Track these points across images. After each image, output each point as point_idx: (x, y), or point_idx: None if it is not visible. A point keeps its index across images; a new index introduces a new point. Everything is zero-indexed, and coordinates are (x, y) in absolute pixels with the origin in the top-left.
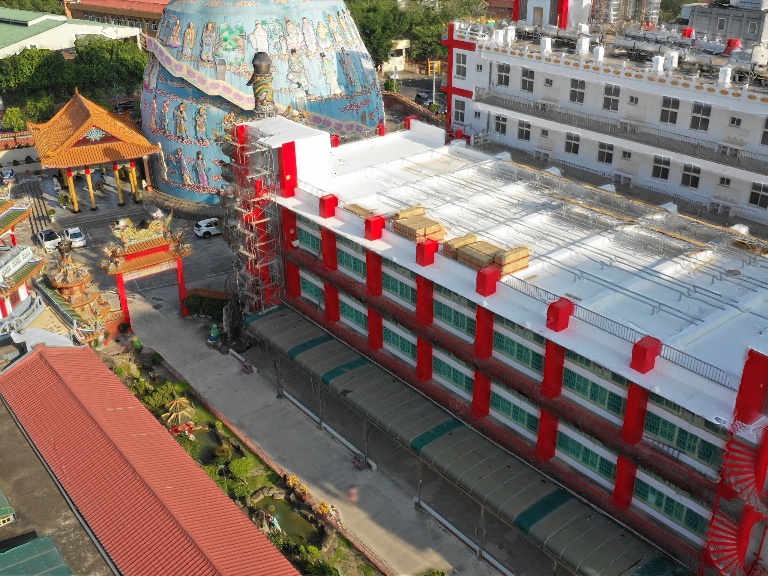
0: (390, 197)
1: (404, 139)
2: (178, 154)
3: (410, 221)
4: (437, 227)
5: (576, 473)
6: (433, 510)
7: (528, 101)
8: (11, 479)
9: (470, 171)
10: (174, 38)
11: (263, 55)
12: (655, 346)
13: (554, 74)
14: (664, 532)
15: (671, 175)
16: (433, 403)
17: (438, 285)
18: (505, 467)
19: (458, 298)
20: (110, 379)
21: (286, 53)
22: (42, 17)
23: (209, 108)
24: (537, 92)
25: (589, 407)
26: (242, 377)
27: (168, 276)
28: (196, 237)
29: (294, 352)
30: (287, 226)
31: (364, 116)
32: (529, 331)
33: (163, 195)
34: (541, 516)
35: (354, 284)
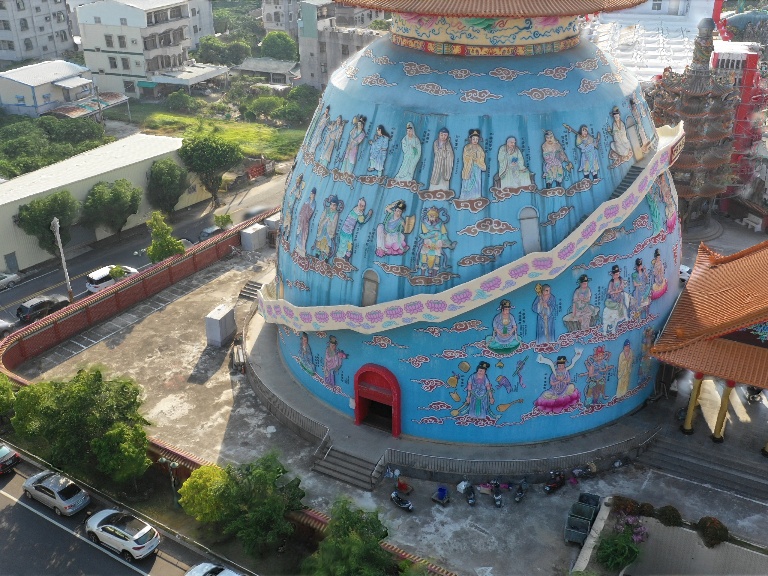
0: None
1: None
2: None
3: None
4: None
5: None
6: None
7: None
8: None
9: None
10: None
11: None
12: None
13: None
14: None
15: None
16: None
17: None
18: None
19: None
20: None
21: None
22: None
23: None
24: None
25: None
26: None
27: None
28: None
29: None
30: None
31: None
32: None
33: None
34: None
35: None
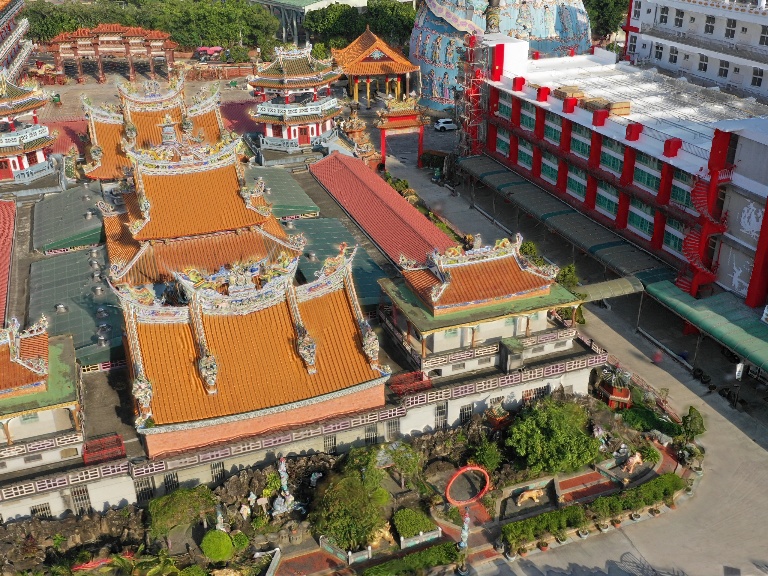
0: (561, 83)
1: (588, 60)
2: (431, 74)
3: (565, 90)
4: (581, 94)
5: None
6: (549, 260)
7: (674, 31)
8: (317, 203)
9: (624, 77)
10: None
11: None
12: (677, 142)
13: (695, 13)
14: None
15: (763, 83)
16: (562, 202)
17: (575, 127)
18: (594, 229)
19: (585, 134)
20: (373, 173)
21: (519, 3)
22: None
23: (458, 41)
24: (684, 27)
25: None
26: (450, 197)
27: (412, 148)
28: (435, 130)
29: (484, 175)
30: (493, 101)
31: None
32: (619, 147)
33: None
34: (605, 247)
35: (526, 131)
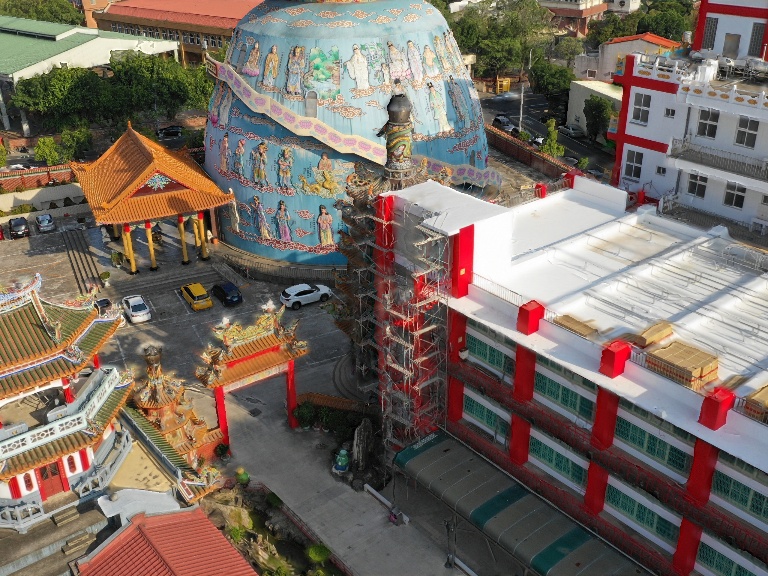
0: (606, 301)
1: (568, 201)
2: (255, 203)
3: (673, 353)
4: (714, 364)
5: None
6: None
7: (758, 162)
8: None
9: (685, 254)
10: (252, 65)
11: (403, 99)
12: None
13: None
14: None
15: None
16: None
17: None
18: None
19: (766, 478)
20: (240, 568)
21: (389, 84)
22: (71, 30)
23: (296, 150)
24: (762, 148)
25: None
26: (390, 530)
27: None
28: None
29: (481, 516)
30: (455, 333)
31: (473, 156)
32: None
33: (233, 249)
34: None
35: (576, 432)
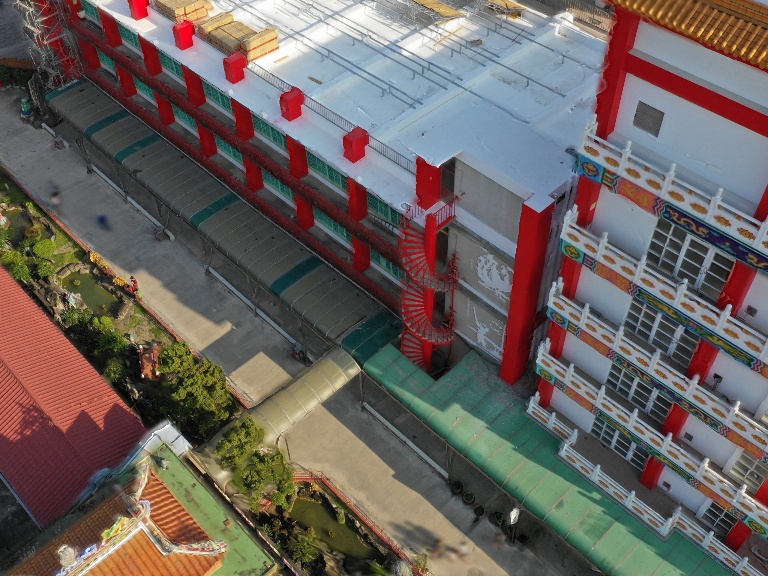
0: None
1: None
2: None
3: None
4: (198, 4)
5: (330, 240)
6: (220, 275)
7: None
8: None
9: None
10: None
11: None
12: (361, 138)
13: None
14: (388, 291)
15: None
16: (215, 179)
17: None
18: (269, 239)
19: None
20: None
21: None
22: None
23: None
24: None
25: (329, 186)
26: (55, 153)
27: None
28: None
29: (90, 131)
30: None
31: None
32: None
33: None
34: (292, 282)
35: (132, 63)
